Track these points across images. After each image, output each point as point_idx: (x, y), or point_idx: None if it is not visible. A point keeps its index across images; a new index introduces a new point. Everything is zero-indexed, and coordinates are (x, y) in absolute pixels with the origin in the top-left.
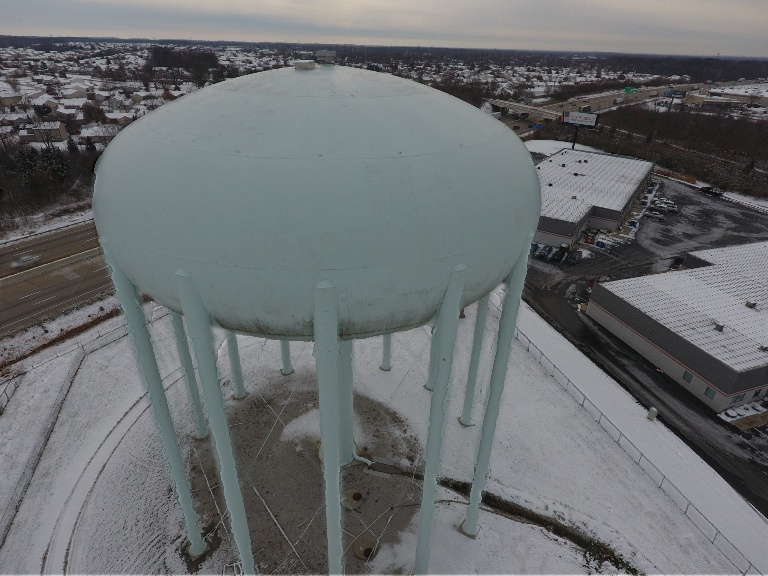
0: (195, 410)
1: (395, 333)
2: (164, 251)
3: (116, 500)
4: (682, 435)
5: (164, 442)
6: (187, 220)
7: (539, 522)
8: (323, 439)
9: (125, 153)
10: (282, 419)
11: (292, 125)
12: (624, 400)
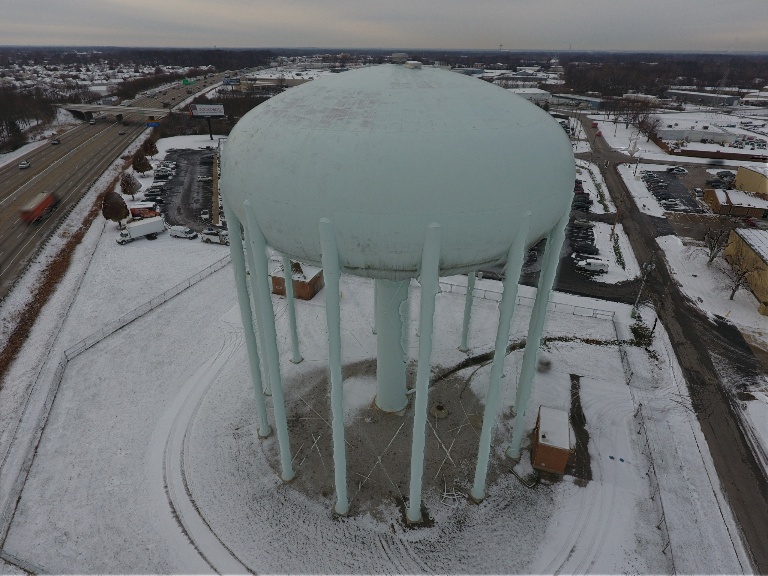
0: (287, 450)
1: (301, 318)
2: (518, 203)
3: (310, 567)
4: (497, 279)
5: (422, 412)
6: (520, 177)
7: (511, 349)
8: (543, 308)
9: (423, 148)
10: (327, 416)
11: (509, 104)
12: (461, 278)
